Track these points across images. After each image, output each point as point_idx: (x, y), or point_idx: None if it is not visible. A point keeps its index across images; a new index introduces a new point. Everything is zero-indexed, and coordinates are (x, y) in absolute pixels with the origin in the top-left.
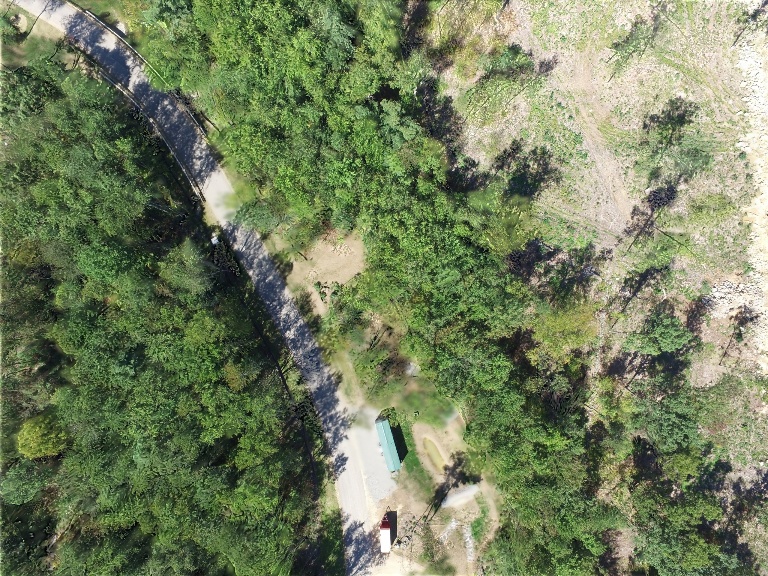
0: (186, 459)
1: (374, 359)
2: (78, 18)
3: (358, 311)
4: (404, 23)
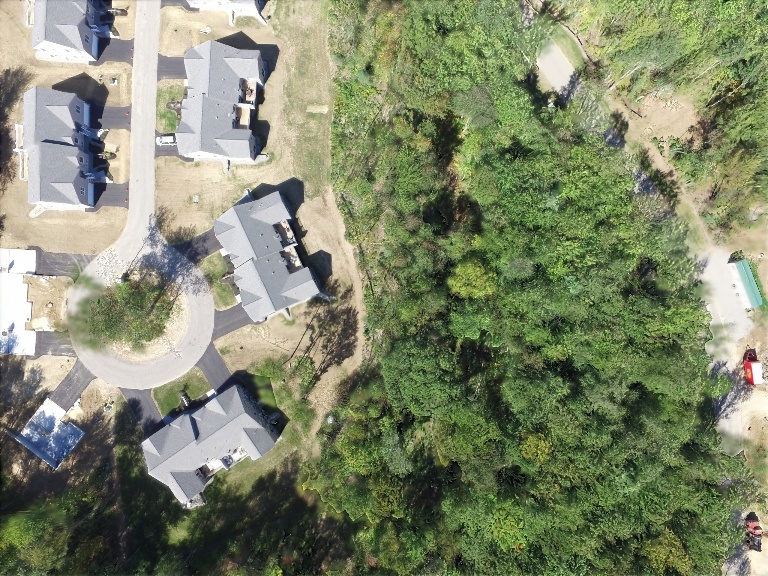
0: (620, 285)
1: (721, 204)
2: None
3: None
4: None
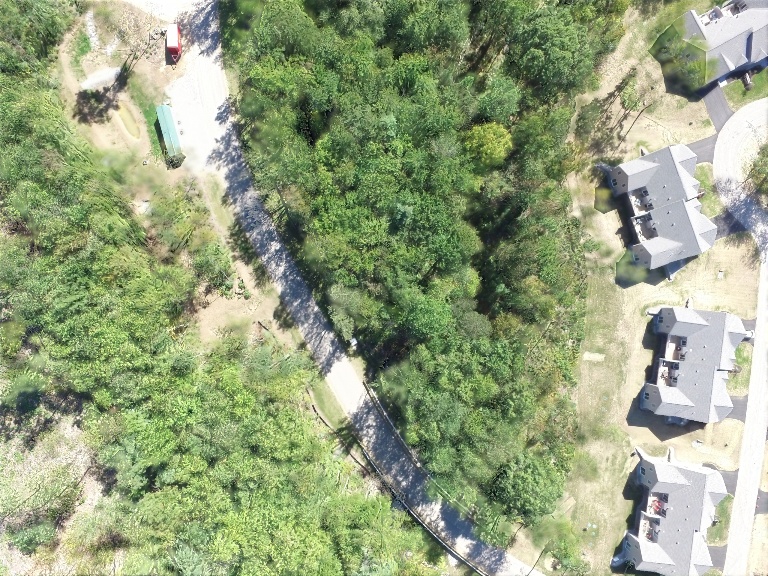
0: (343, 119)
1: (186, 219)
2: (494, 569)
3: (204, 269)
4: (156, 575)
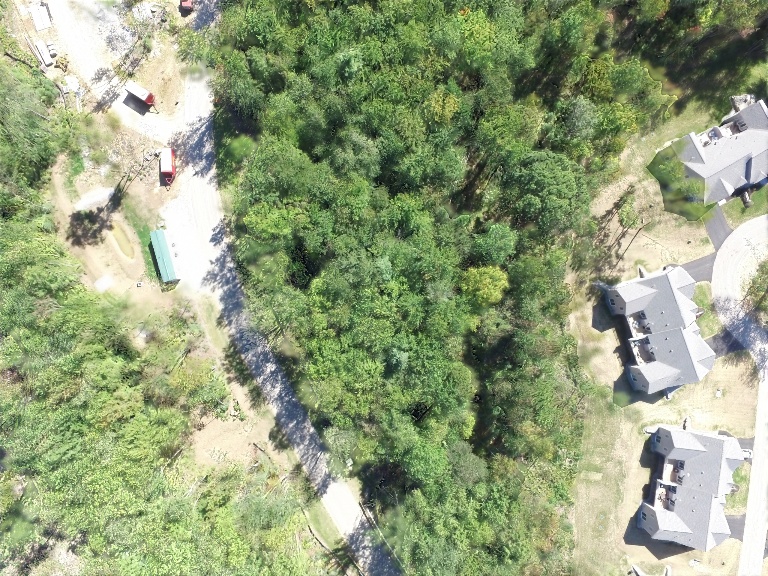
0: (338, 265)
1: (181, 343)
2: None
3: (198, 392)
4: None
